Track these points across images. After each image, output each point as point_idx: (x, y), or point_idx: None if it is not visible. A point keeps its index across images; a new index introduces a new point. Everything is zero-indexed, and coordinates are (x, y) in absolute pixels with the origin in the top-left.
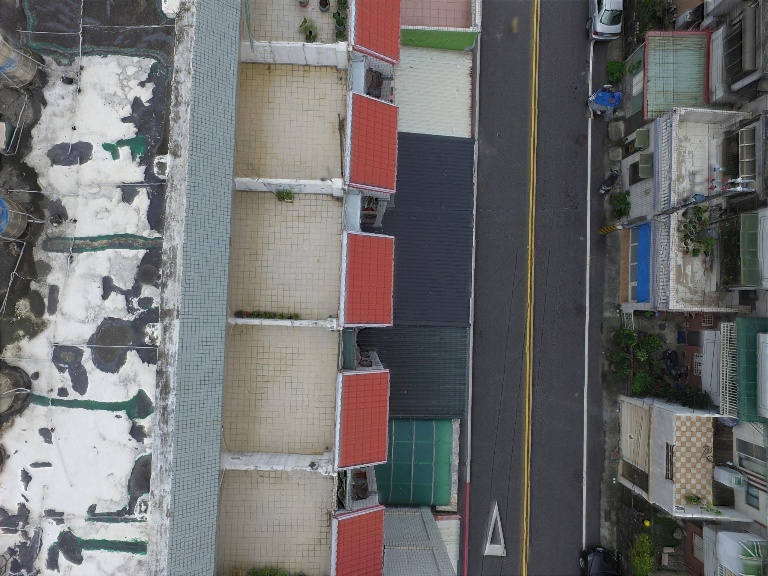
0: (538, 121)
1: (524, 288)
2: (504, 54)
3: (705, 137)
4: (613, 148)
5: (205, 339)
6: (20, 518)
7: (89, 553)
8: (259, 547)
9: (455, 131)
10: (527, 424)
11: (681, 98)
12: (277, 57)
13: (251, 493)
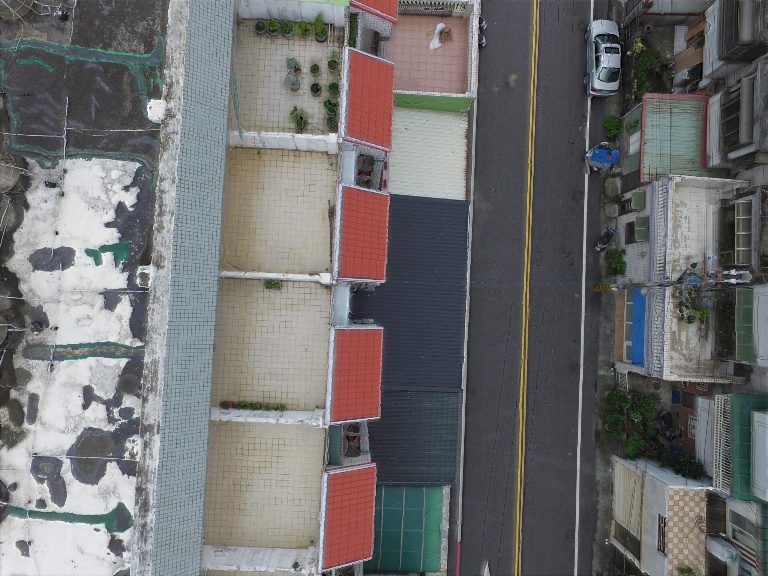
0: (534, 176)
1: (518, 345)
2: (501, 108)
3: (702, 202)
4: (609, 204)
5: (186, 451)
6: None
7: None
8: None
9: (449, 193)
10: (519, 483)
11: (678, 161)
12: (267, 143)
13: None
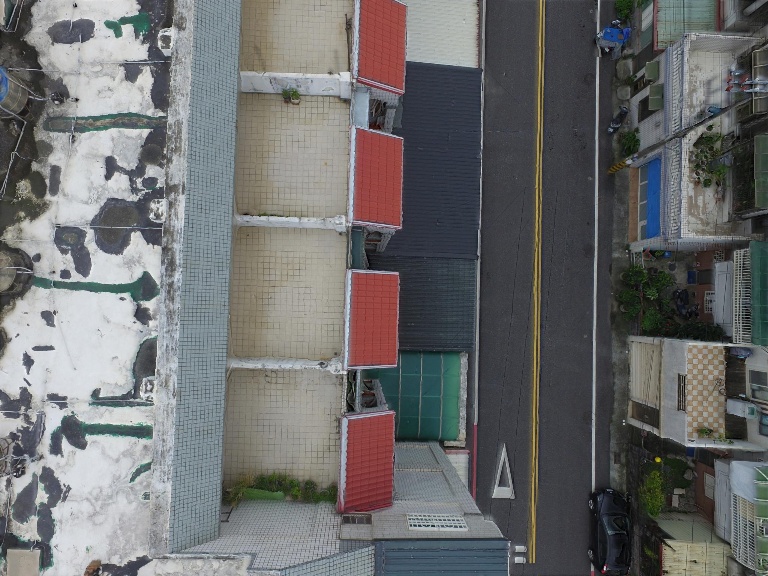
0: (545, 60)
1: (532, 229)
2: None
3: (716, 67)
4: (621, 87)
5: (211, 220)
6: (22, 402)
7: (93, 438)
8: (267, 454)
9: (462, 61)
10: (535, 365)
11: (692, 28)
12: None
13: (258, 399)
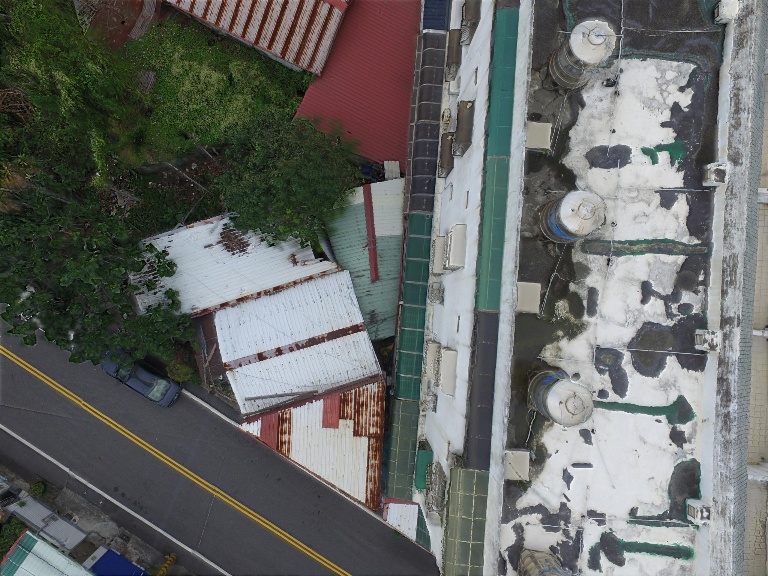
0: None
1: None
2: None
3: None
4: None
5: (746, 348)
6: (562, 517)
7: (631, 555)
8: None
9: None
10: None
11: None
12: None
13: None
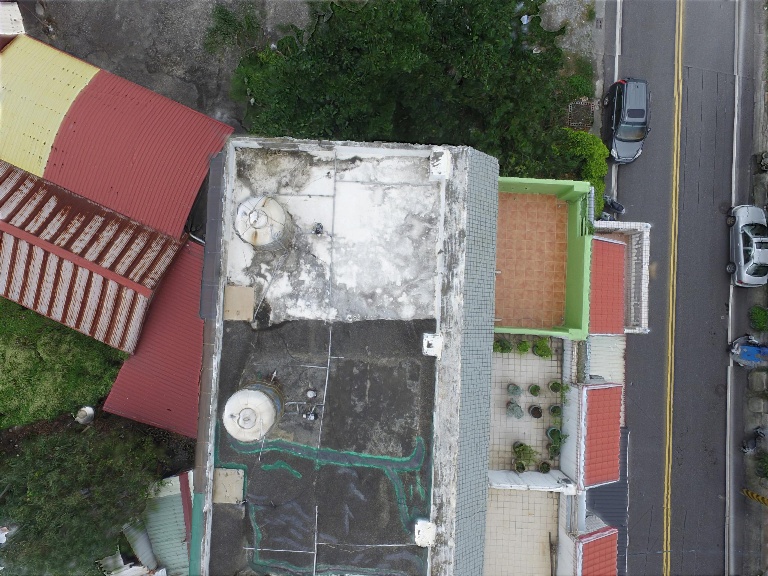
0: (674, 369)
1: None
2: (638, 296)
3: None
4: (753, 399)
5: None
6: None
7: None
8: None
9: None
10: None
11: None
12: None
13: None
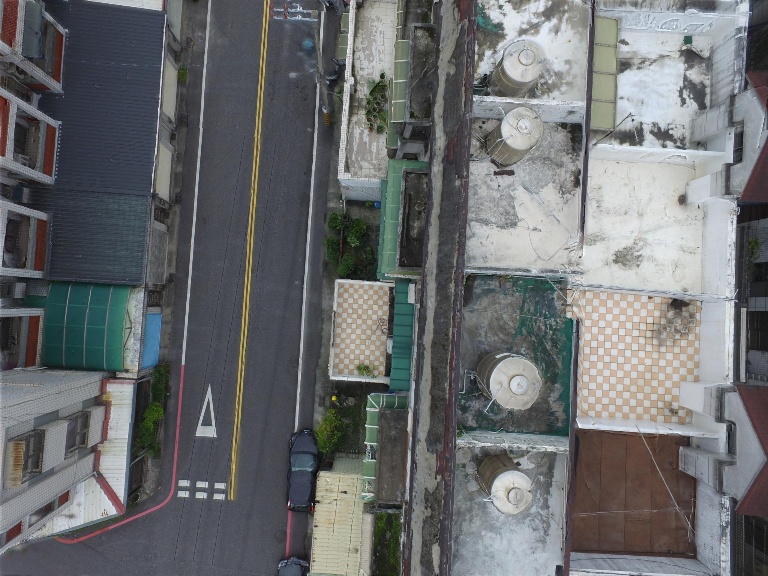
0: None
1: (249, 176)
2: None
3: None
4: None
5: None
6: None
7: None
8: None
9: (145, 3)
10: (244, 309)
11: None
12: None
13: None
